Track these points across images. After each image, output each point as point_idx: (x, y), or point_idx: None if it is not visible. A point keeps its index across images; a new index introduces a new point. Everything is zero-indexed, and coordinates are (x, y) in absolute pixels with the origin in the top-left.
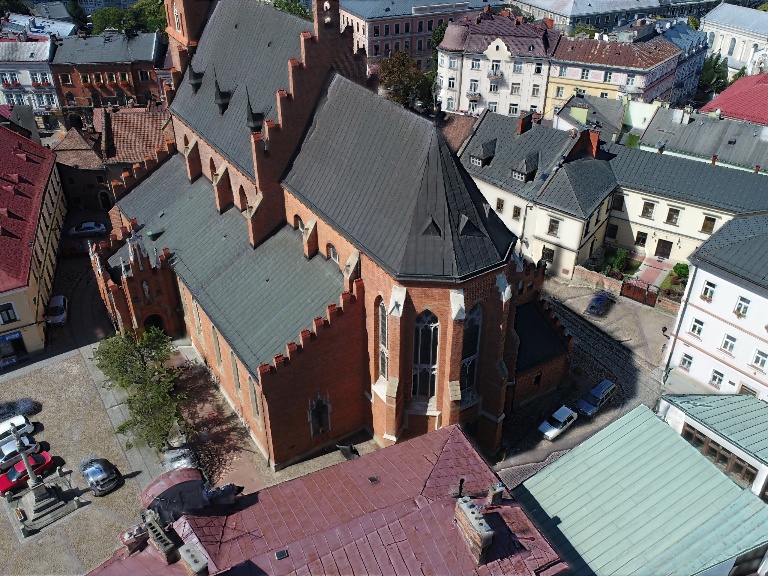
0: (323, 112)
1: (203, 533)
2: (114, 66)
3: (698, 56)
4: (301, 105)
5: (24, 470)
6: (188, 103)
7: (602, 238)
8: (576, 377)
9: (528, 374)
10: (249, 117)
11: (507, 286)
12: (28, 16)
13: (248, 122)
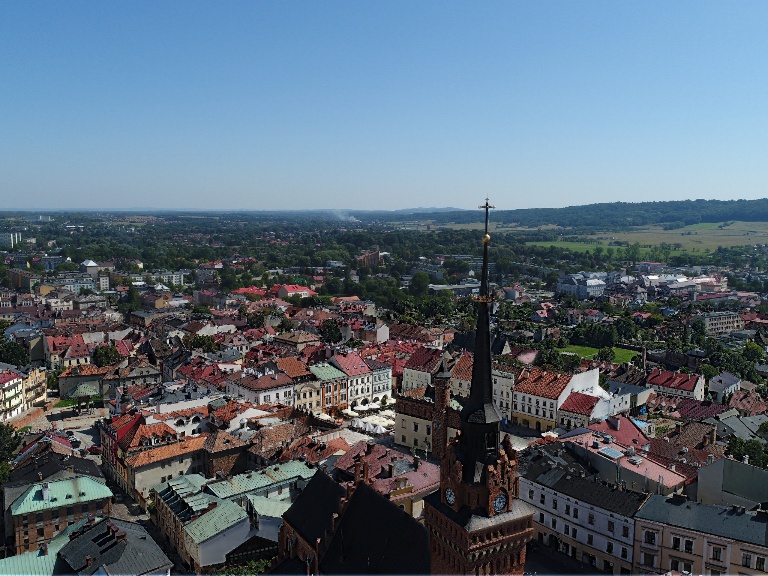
0: None
1: None
2: None
3: None
4: None
5: None
6: None
7: None
8: None
9: None
10: None
11: None
12: None
13: None
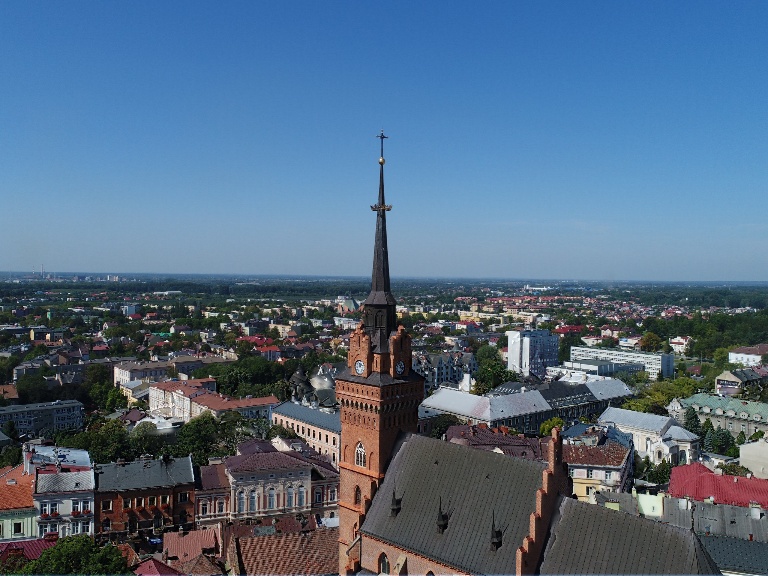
0: (561, 526)
1: None
2: (158, 490)
3: (632, 452)
4: (544, 522)
5: None
6: (387, 525)
7: None
8: None
9: None
10: (493, 534)
11: None
12: (44, 446)
13: (492, 538)
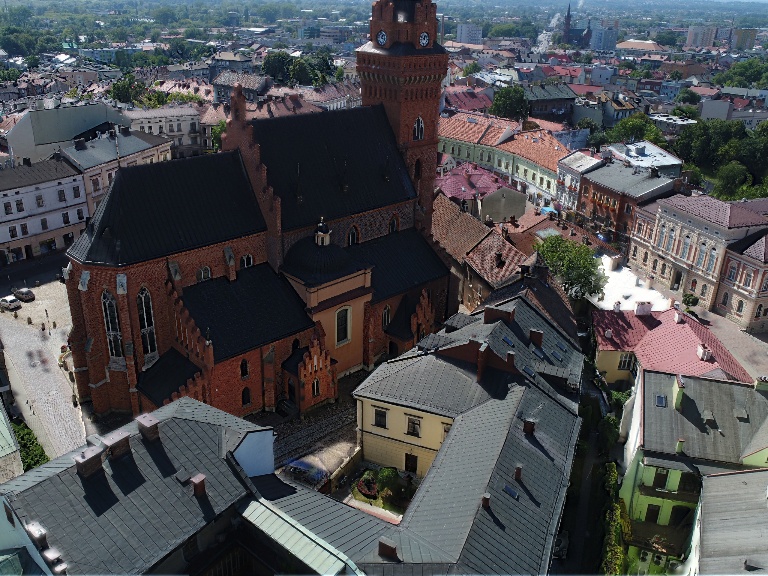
0: None
1: None
2: (612, 192)
3: None
4: None
5: None
6: None
7: None
8: None
9: None
10: None
11: (84, 281)
12: (656, 146)
13: None
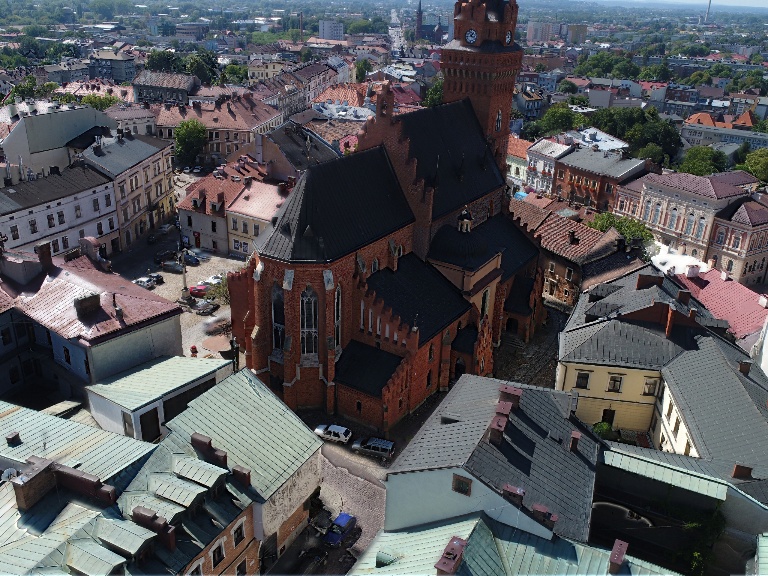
0: None
1: (79, 261)
2: (591, 174)
3: None
4: None
5: (198, 288)
6: None
7: (645, 425)
8: (402, 439)
9: (349, 392)
10: None
11: (289, 280)
12: (602, 132)
13: None
